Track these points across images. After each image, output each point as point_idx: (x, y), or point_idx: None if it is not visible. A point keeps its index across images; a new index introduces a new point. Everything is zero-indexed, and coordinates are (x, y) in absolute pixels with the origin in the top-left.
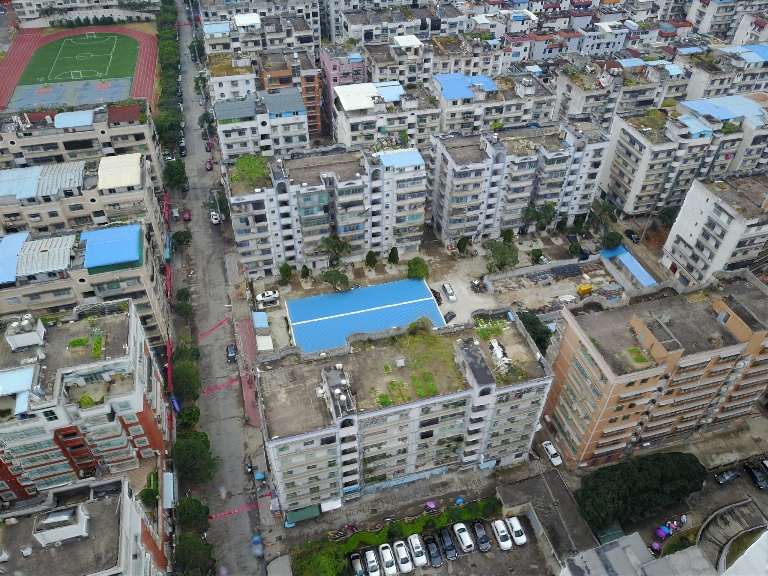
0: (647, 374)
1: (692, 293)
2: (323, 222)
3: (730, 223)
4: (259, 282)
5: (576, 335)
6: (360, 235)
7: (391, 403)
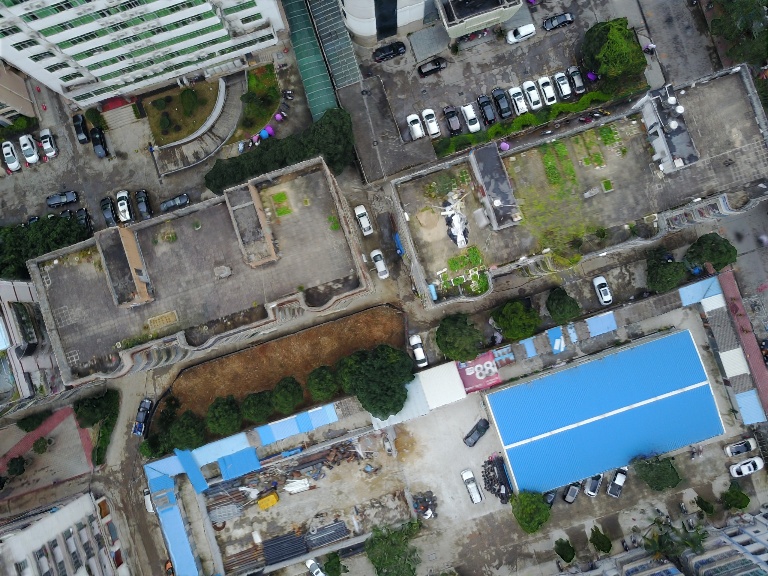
0: (277, 175)
1: (165, 333)
2: (716, 571)
3: (24, 561)
4: (766, 499)
5: (352, 245)
6: (636, 573)
7: (599, 133)
